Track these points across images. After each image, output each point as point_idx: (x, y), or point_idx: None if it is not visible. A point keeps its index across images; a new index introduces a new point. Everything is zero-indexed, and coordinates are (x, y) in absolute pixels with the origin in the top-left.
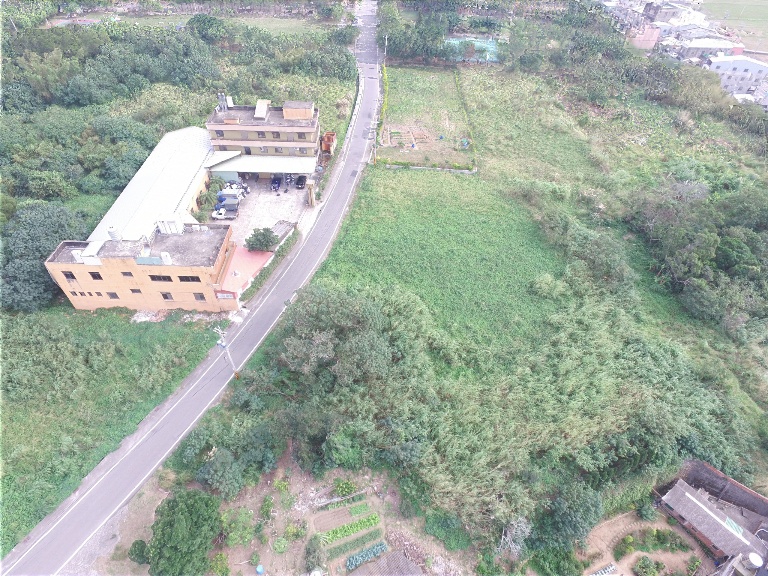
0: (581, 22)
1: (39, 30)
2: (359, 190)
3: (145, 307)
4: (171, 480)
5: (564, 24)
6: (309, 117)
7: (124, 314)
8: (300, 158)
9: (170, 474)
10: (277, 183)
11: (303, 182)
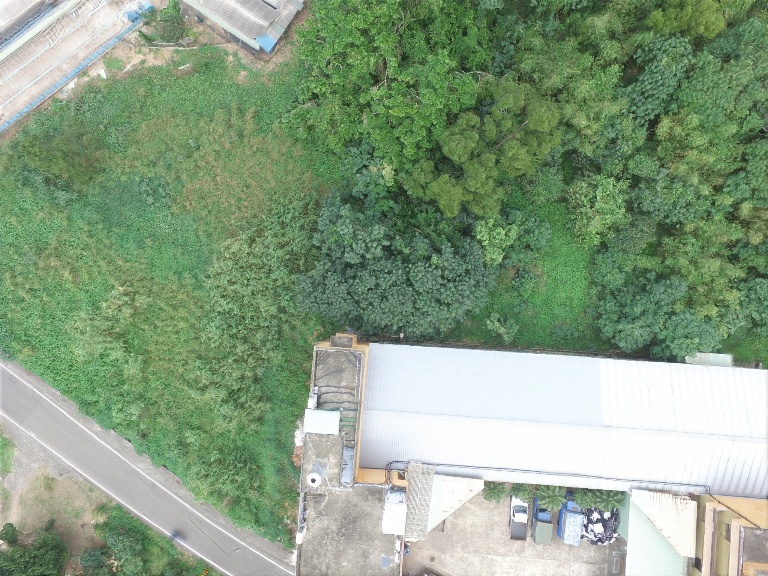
0: None
1: None
2: None
3: None
4: (98, 519)
5: None
6: None
7: None
8: None
9: (102, 518)
10: None
11: None
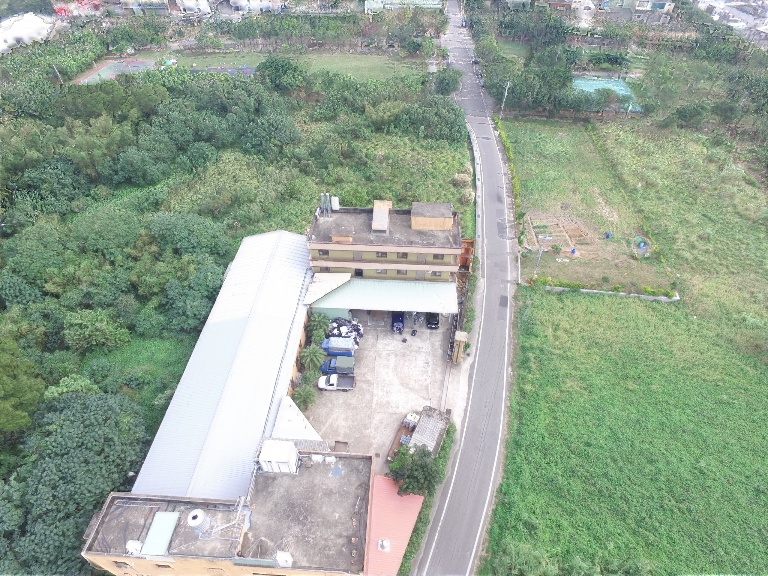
0: (726, 54)
1: (85, 87)
2: (518, 333)
3: None
4: None
5: (705, 57)
6: (448, 228)
7: None
8: (432, 284)
9: None
10: (401, 321)
11: (437, 320)
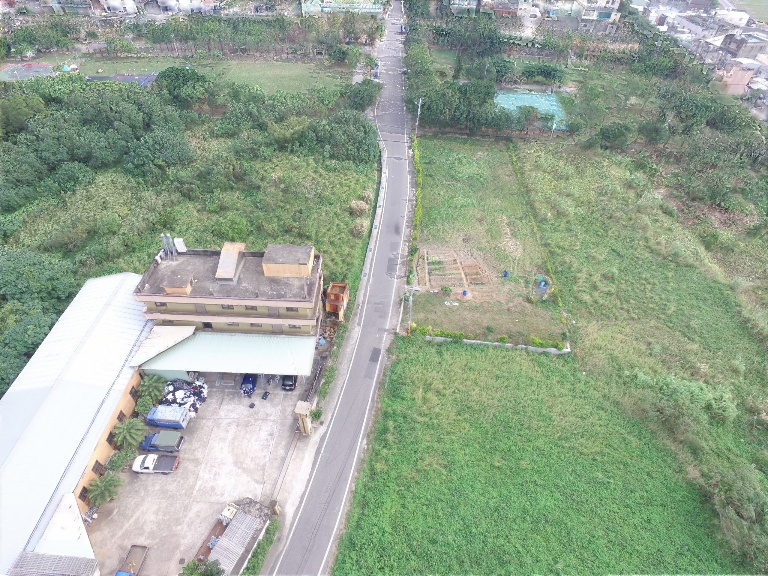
0: (663, 68)
1: None
2: (384, 395)
3: None
4: None
5: (642, 71)
6: (305, 275)
7: None
8: (289, 338)
9: None
10: (251, 383)
11: (293, 380)
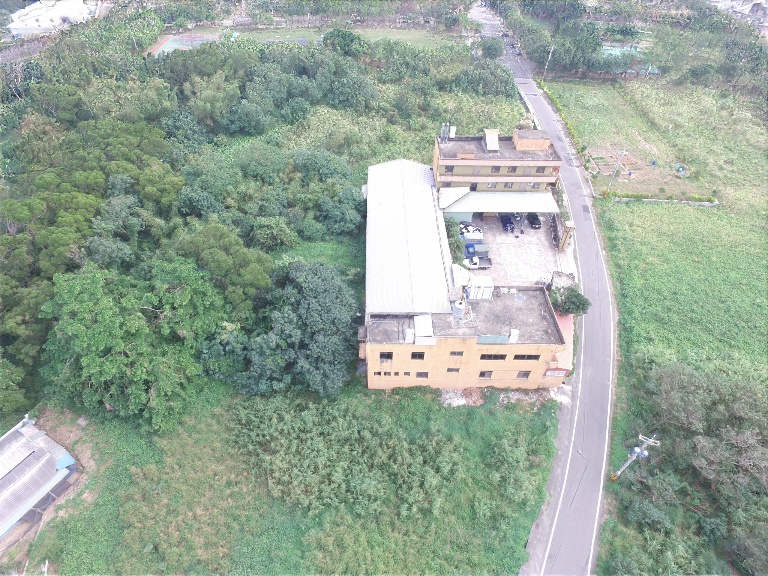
0: (718, 27)
1: (189, 51)
2: (603, 229)
3: (451, 385)
4: None
5: (701, 29)
6: (545, 148)
7: (429, 394)
8: (534, 194)
9: None
10: (512, 223)
11: None
